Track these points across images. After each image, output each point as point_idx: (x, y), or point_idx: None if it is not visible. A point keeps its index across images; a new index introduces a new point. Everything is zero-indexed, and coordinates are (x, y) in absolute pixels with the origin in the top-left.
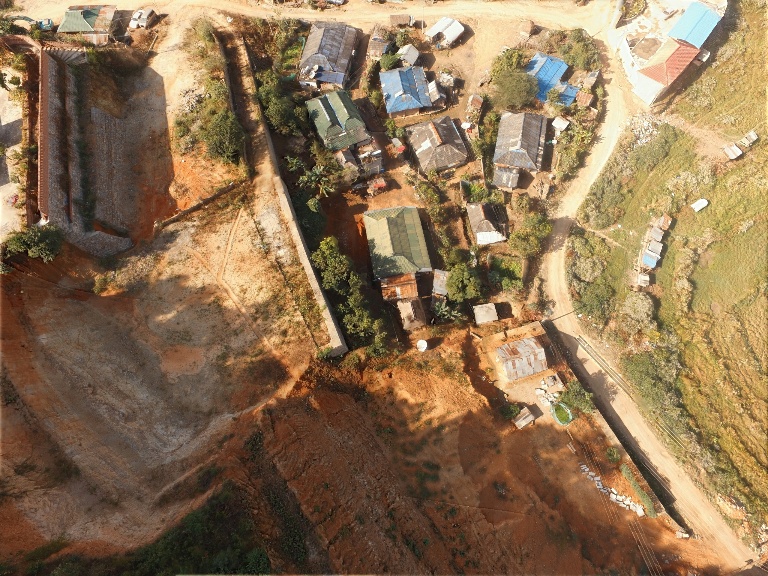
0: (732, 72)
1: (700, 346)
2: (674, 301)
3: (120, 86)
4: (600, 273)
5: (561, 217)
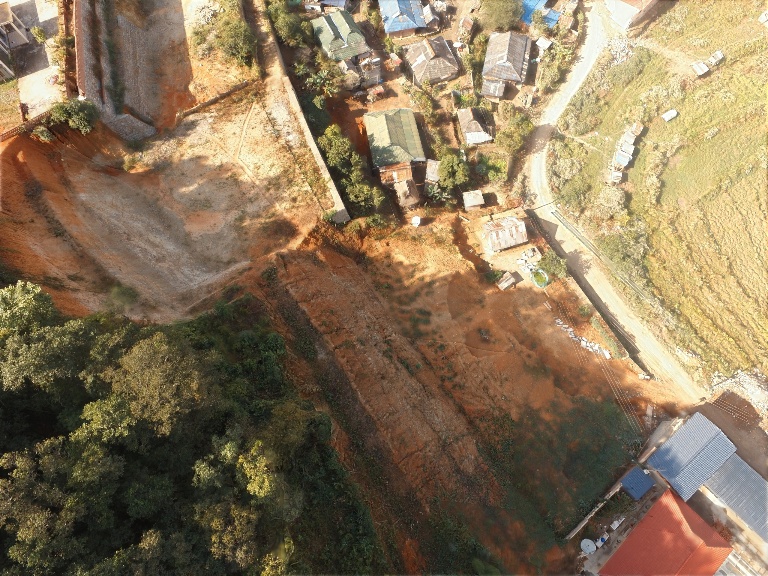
0: (703, 2)
1: (666, 232)
2: (644, 195)
3: (141, 3)
4: (578, 171)
5: (543, 124)
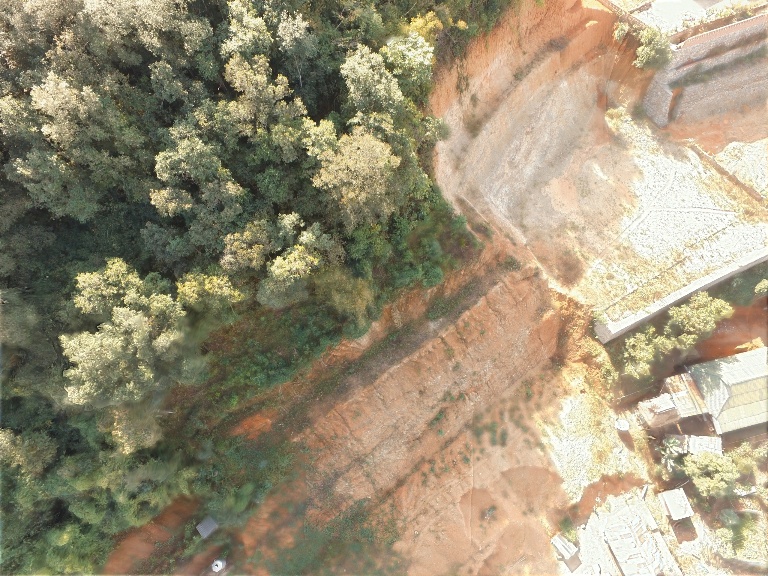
0: None
1: None
2: None
3: None
4: None
5: None
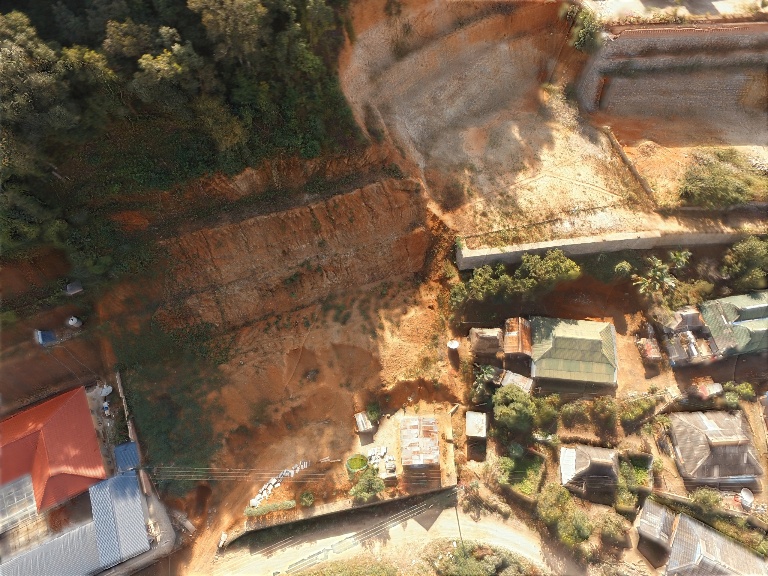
0: None
1: None
2: None
3: None
4: None
5: None
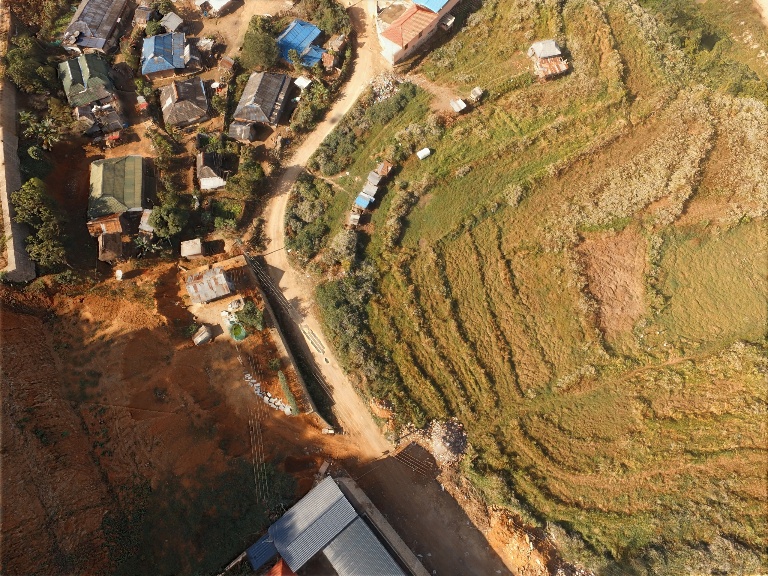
0: (478, 36)
1: (395, 275)
2: (382, 237)
3: None
4: (319, 214)
5: (293, 166)
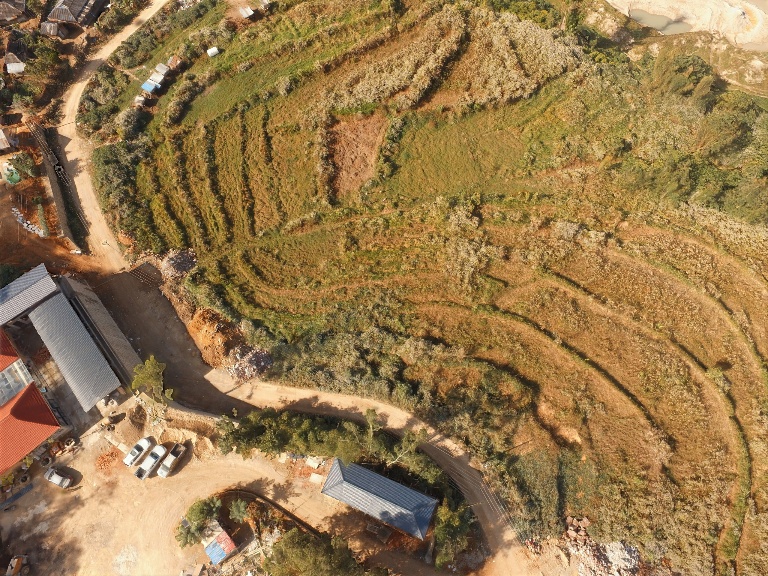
0: None
1: (167, 144)
2: None
3: None
4: (112, 97)
5: (96, 59)
